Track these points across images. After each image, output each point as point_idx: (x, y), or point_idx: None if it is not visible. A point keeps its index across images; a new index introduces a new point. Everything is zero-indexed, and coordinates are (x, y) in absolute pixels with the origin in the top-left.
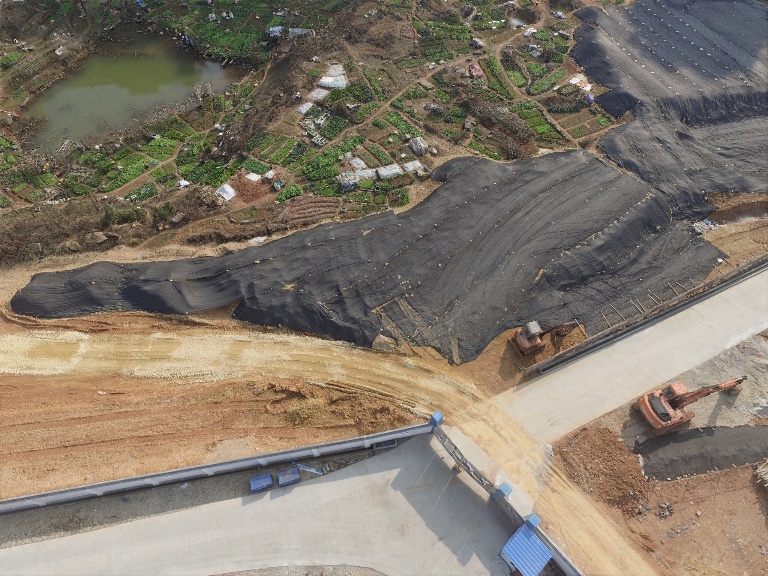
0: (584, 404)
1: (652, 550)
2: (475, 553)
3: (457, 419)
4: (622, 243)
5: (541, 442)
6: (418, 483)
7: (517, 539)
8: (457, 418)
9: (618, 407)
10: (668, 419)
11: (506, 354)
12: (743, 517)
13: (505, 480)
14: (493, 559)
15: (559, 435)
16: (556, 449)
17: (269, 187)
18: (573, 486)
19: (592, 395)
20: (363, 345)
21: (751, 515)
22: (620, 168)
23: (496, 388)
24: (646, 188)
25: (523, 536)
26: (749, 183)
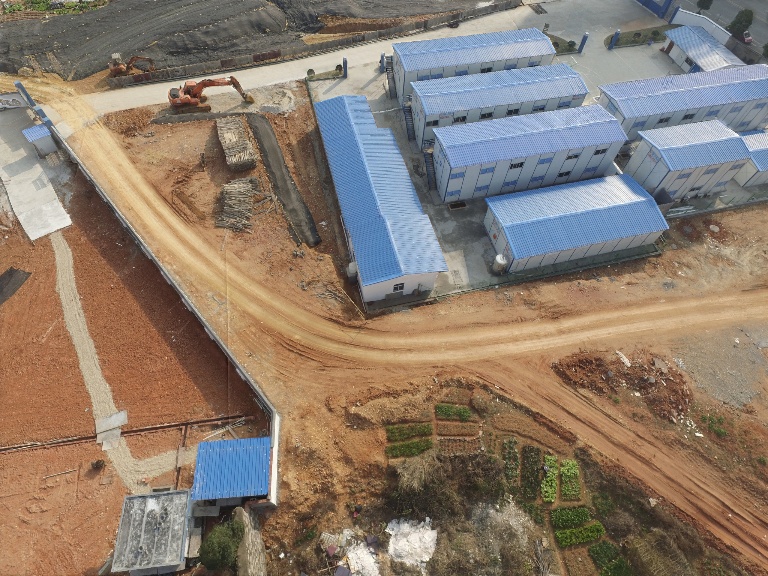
0: (142, 100)
1: (129, 148)
2: (23, 148)
3: (51, 102)
4: (228, 33)
5: (99, 112)
6: (7, 124)
7: (33, 128)
8: (52, 102)
9: (164, 103)
10: (176, 97)
11: (105, 78)
12: (195, 138)
13: (63, 124)
14: (32, 150)
15: (114, 111)
16: (106, 115)
17: (1, 7)
18: (104, 127)
19: (151, 97)
20: (13, 73)
21: (201, 137)
22: (268, 2)
23: (87, 91)
24: (262, 5)
25: (38, 127)
26: (358, 12)
